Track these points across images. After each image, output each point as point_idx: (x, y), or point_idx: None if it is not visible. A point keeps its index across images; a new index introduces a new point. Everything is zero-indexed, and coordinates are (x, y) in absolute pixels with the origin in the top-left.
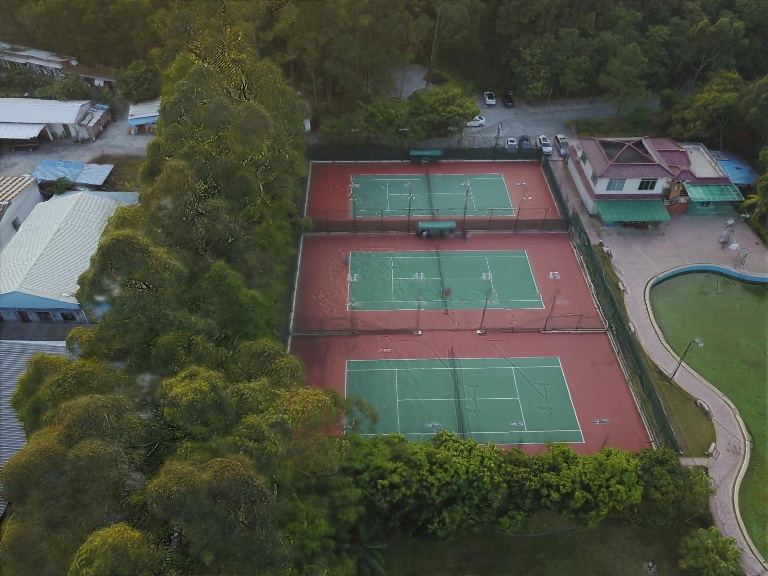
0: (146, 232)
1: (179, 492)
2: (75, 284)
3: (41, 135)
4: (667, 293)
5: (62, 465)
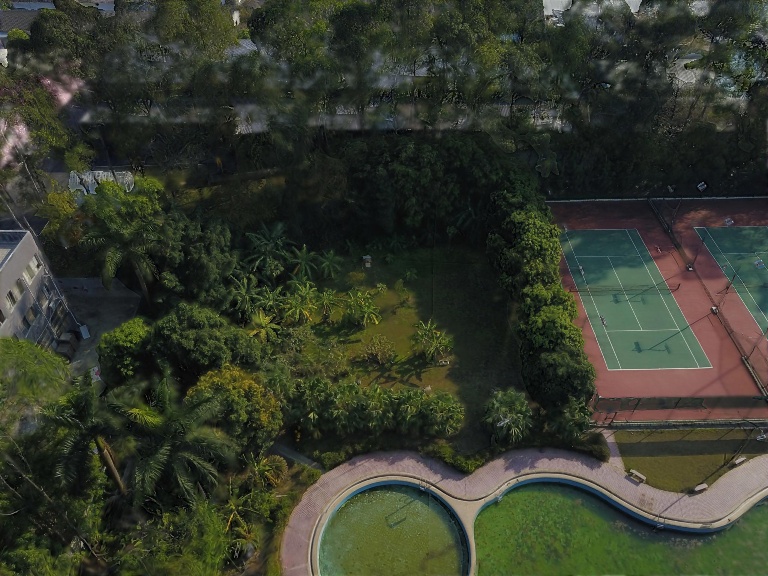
0: None
1: None
2: None
3: None
4: None
5: None
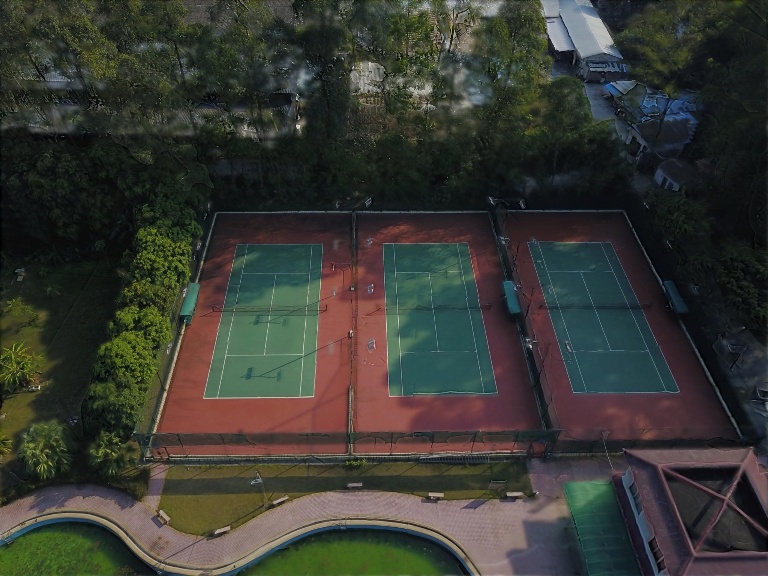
0: None
1: None
2: (368, 90)
3: (565, 53)
4: (438, 571)
5: None
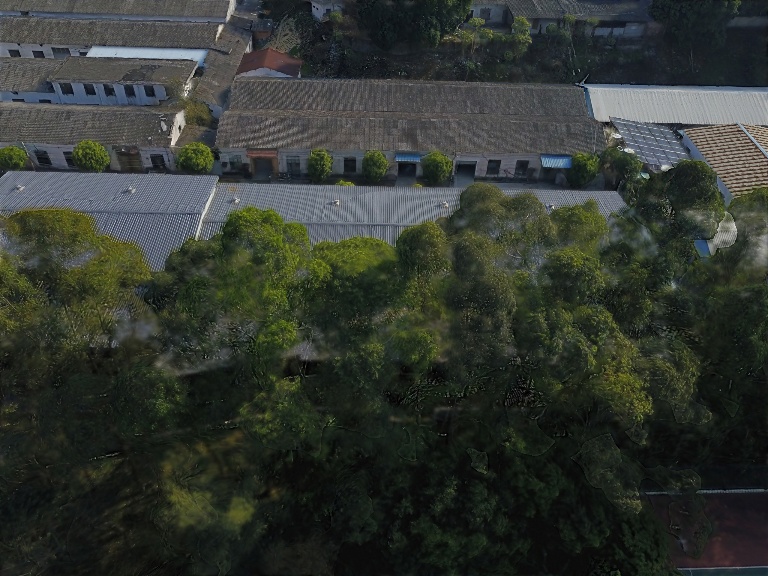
0: (761, 219)
1: (466, 248)
2: None
3: None
4: None
5: (484, 205)
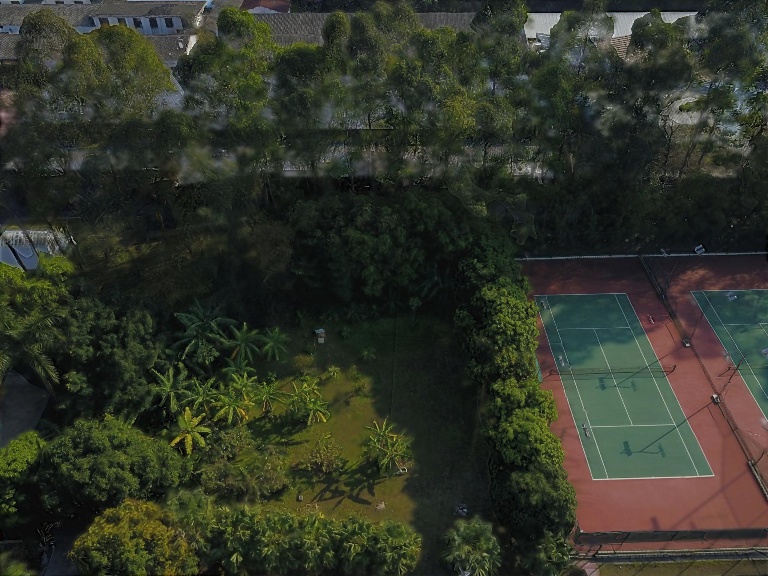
0: None
1: (354, 18)
2: None
3: None
4: None
5: None
